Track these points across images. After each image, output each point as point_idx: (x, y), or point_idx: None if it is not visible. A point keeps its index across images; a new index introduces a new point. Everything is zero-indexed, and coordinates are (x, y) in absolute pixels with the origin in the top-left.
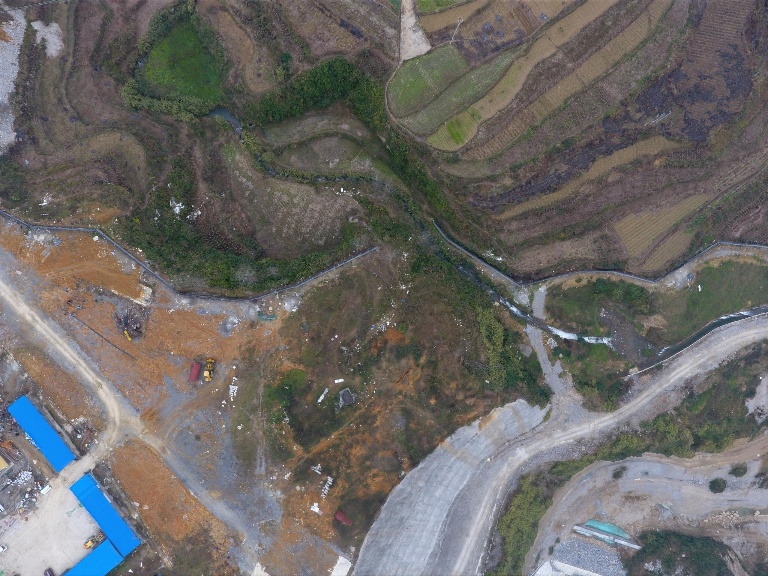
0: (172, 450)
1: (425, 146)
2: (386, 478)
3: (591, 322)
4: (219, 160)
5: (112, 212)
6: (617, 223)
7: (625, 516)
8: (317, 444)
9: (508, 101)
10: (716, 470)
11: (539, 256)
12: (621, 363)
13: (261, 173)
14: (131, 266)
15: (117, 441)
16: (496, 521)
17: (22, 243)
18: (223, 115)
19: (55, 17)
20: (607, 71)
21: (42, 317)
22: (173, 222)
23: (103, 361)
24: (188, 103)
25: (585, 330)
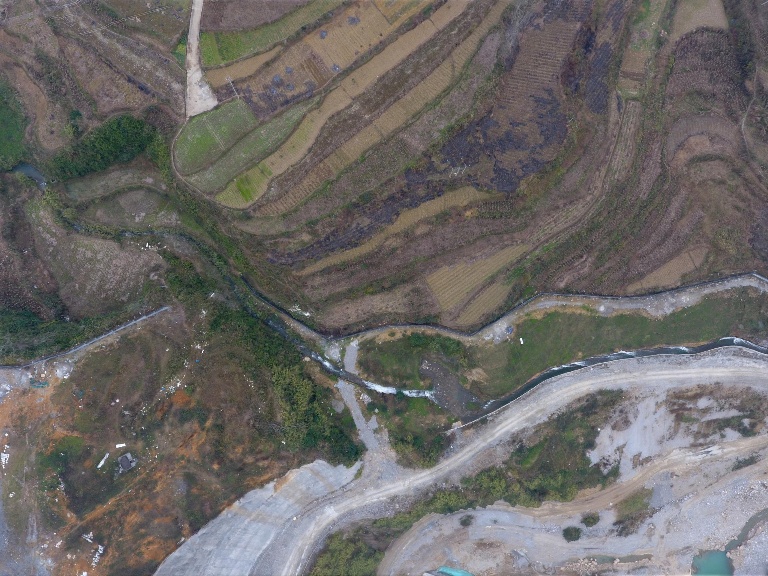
0: None
1: (212, 204)
2: (162, 546)
3: (411, 375)
4: (22, 216)
5: None
6: (430, 276)
7: (476, 564)
8: (92, 511)
9: (300, 156)
10: (566, 519)
11: (348, 311)
12: (442, 417)
13: (65, 229)
14: None
15: None
16: None
17: None
18: (27, 171)
19: None
20: (407, 122)
21: None
22: None
23: None
24: None
25: (403, 384)
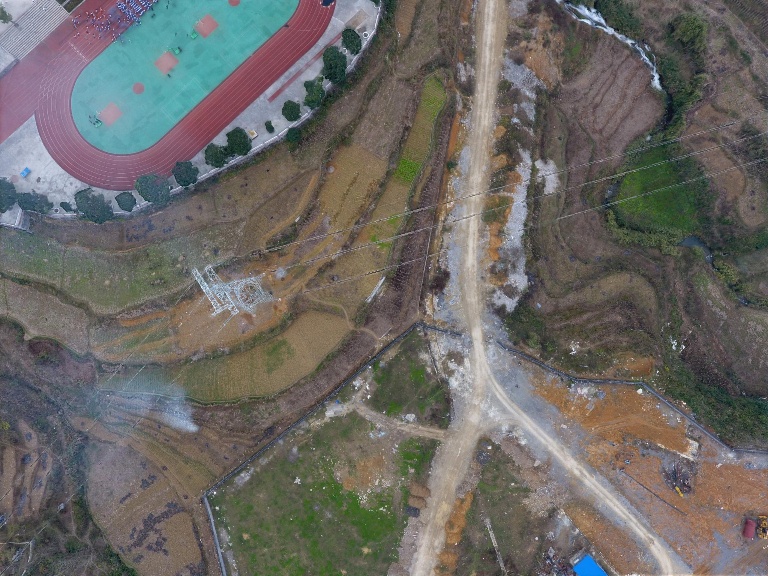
0: None
1: None
2: None
3: None
4: None
5: (646, 362)
6: None
7: None
8: None
9: None
10: None
11: None
12: None
13: (734, 302)
14: (676, 419)
15: None
16: None
17: (566, 396)
18: (694, 243)
19: (550, 153)
20: None
21: (590, 472)
22: None
23: (654, 516)
24: (669, 234)
25: None
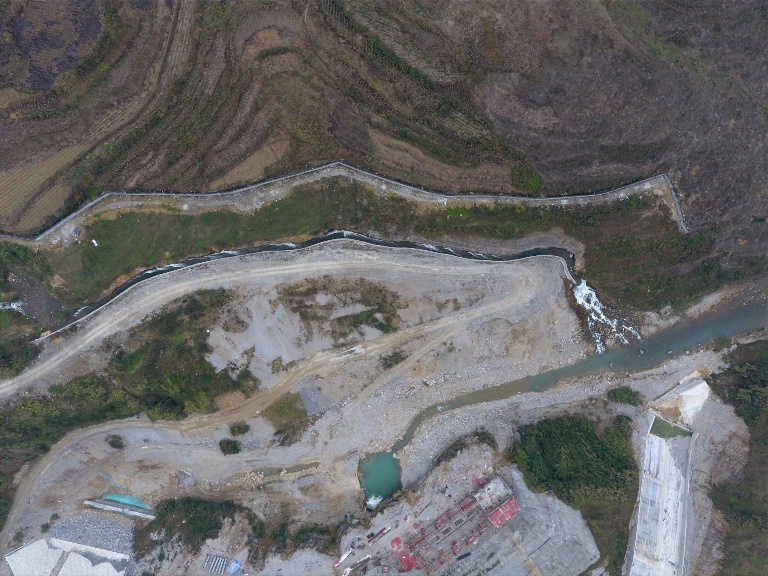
0: None
1: None
2: None
3: None
4: None
5: None
6: None
7: (136, 486)
8: None
9: None
10: (214, 431)
11: None
12: (27, 327)
13: None
14: None
15: None
16: None
17: None
18: None
19: None
20: None
21: None
22: None
23: None
24: None
25: None
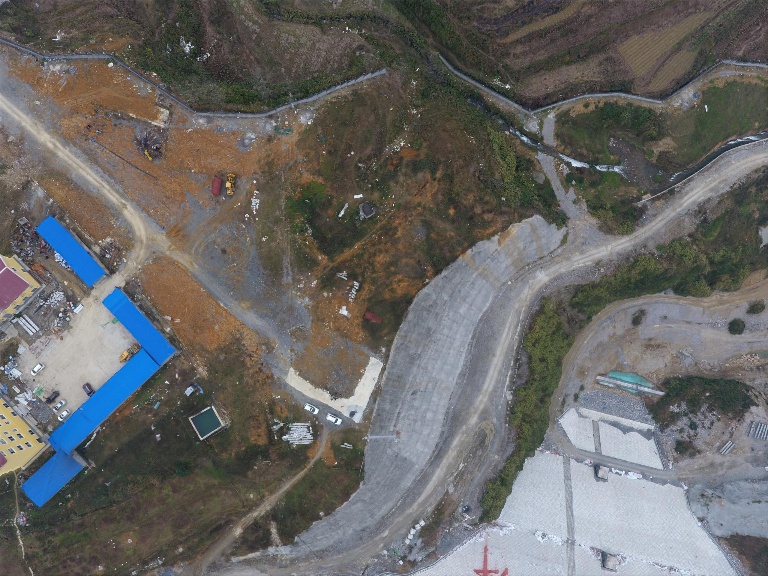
0: (199, 264)
1: None
2: (411, 283)
3: (601, 150)
4: (224, 6)
5: (124, 42)
6: (621, 45)
7: (647, 363)
8: (341, 254)
9: None
10: (734, 309)
11: (546, 81)
12: (634, 189)
13: (266, 16)
14: (147, 90)
15: (145, 259)
16: (521, 340)
17: (39, 74)
18: None
19: None
20: None
21: (63, 144)
22: (184, 59)
23: (126, 182)
24: None
25: (596, 157)
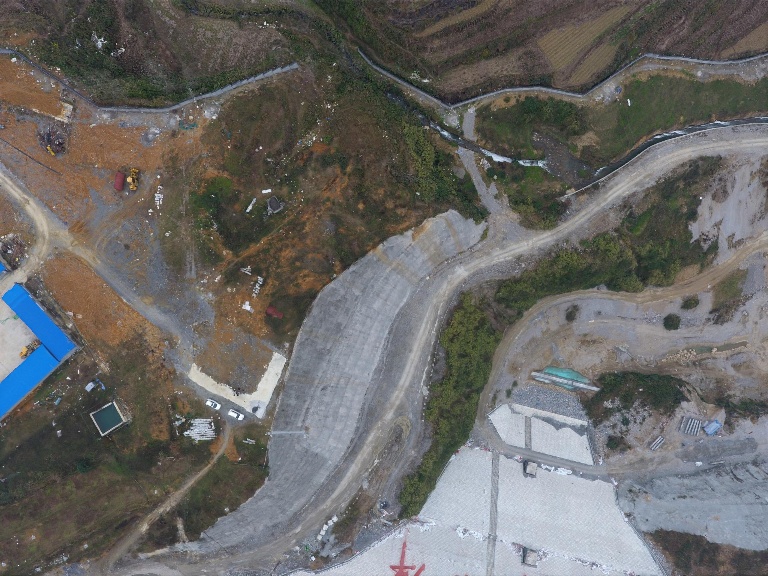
0: (102, 260)
1: None
2: (317, 278)
3: (524, 145)
4: (141, 1)
5: (29, 36)
6: (540, 39)
7: (582, 359)
8: (247, 249)
9: None
10: (668, 304)
11: (465, 76)
12: (557, 184)
13: (183, 11)
14: (50, 85)
15: (47, 254)
16: (438, 335)
17: None
18: None
19: None
20: None
21: None
22: (95, 54)
23: (28, 178)
24: None
25: (518, 152)
